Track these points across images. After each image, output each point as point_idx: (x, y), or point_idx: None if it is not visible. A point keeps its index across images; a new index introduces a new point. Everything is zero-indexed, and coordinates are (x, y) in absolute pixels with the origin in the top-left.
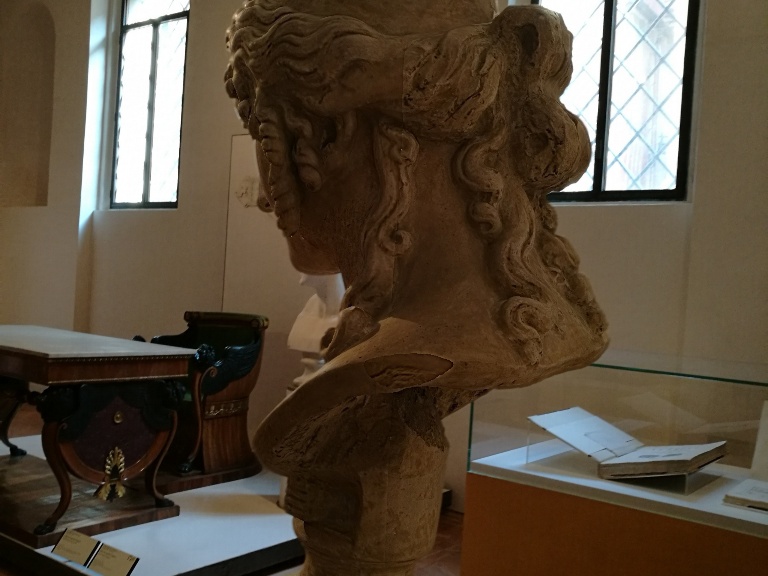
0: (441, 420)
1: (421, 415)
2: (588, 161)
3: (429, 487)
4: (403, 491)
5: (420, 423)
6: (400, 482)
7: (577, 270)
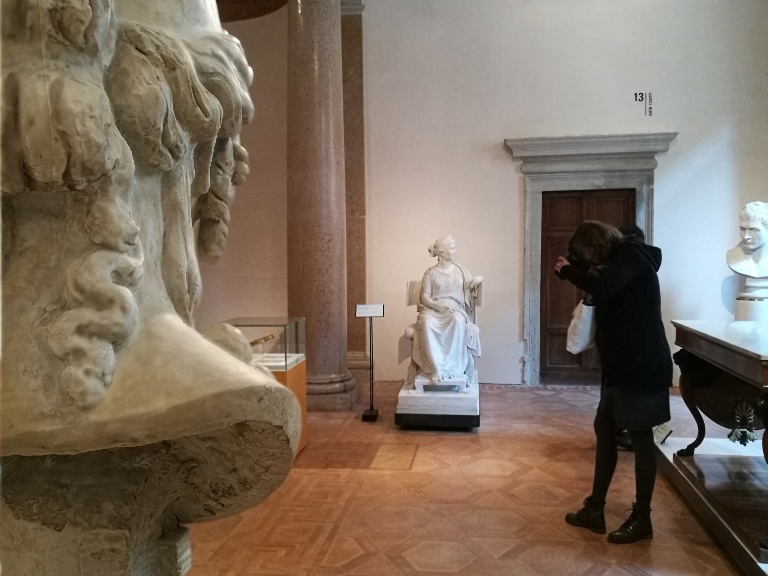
0: (250, 496)
1: (36, 480)
2: (27, 144)
3: (36, 569)
4: (6, 564)
5: (24, 489)
6: (2, 552)
7: (111, 304)
